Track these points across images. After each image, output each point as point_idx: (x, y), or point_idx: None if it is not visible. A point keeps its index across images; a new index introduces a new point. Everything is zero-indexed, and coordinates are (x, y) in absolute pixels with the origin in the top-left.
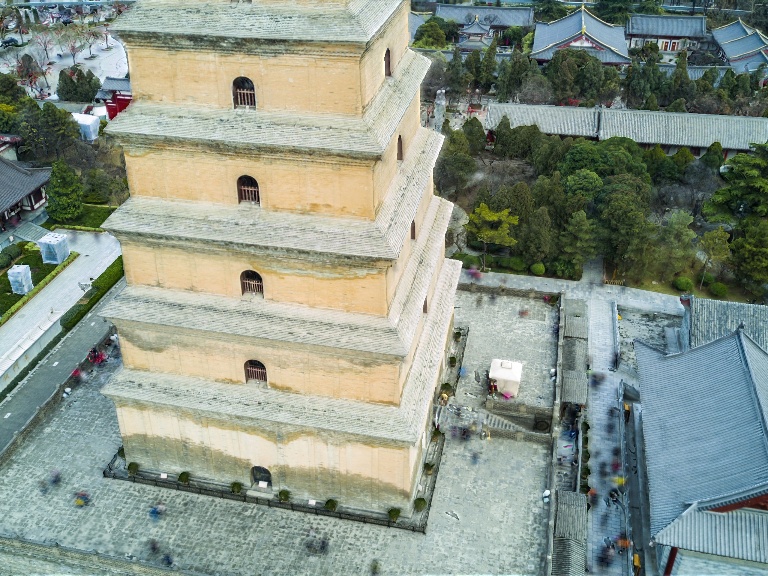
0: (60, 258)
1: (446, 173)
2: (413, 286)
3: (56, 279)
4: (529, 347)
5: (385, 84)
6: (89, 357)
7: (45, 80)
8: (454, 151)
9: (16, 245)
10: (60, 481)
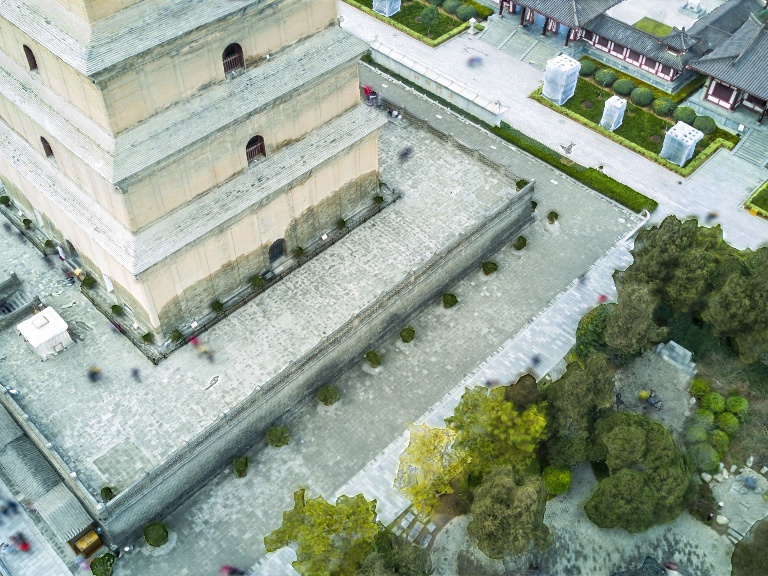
0: (665, 152)
1: None
2: (0, 68)
3: (631, 152)
4: (73, 406)
5: None
6: (366, 89)
7: None
8: None
9: (711, 124)
10: None
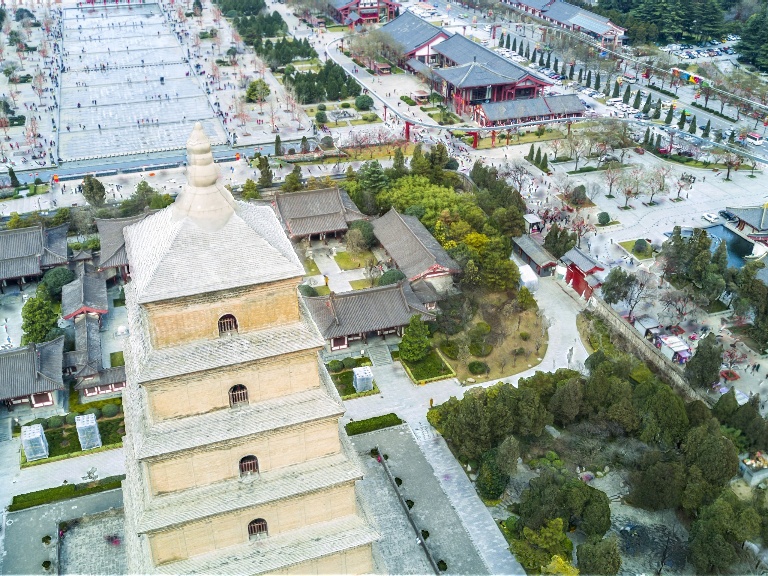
0: (360, 389)
1: (682, 545)
2: None
3: (344, 402)
4: None
5: (235, 479)
6: None
7: (577, 214)
8: (730, 528)
9: (354, 360)
10: (117, 549)
